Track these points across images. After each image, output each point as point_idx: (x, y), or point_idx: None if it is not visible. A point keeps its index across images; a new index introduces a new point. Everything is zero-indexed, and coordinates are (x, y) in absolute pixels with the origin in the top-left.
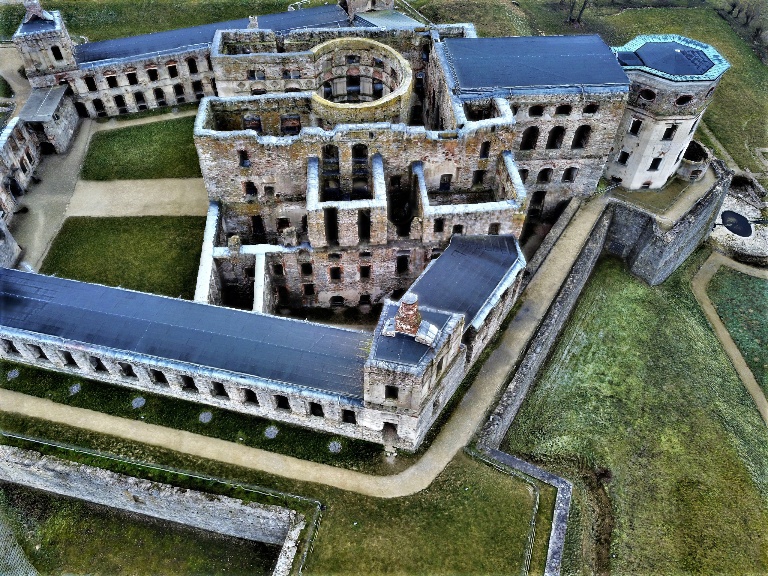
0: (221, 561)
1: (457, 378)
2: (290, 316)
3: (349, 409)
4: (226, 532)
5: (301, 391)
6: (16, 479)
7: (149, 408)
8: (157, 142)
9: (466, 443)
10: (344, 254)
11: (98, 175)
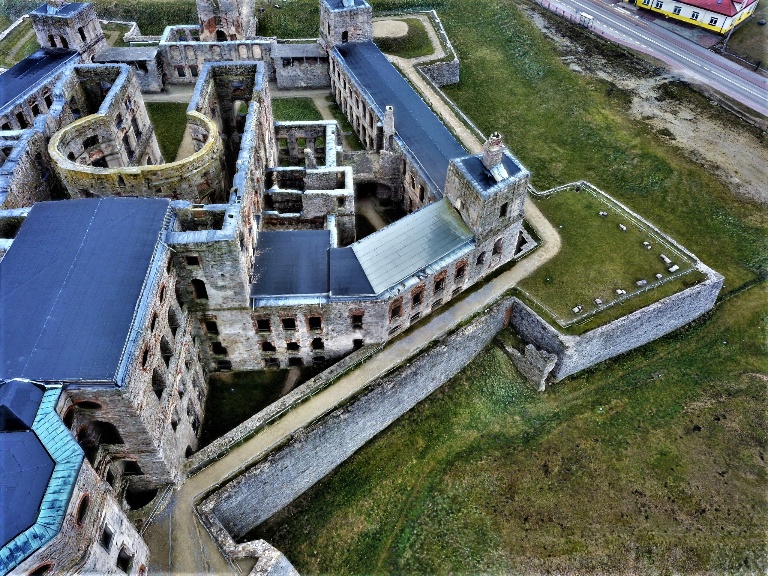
0: None
1: None
2: None
3: None
4: None
5: None
6: None
7: None
8: None
9: None
10: None
11: None
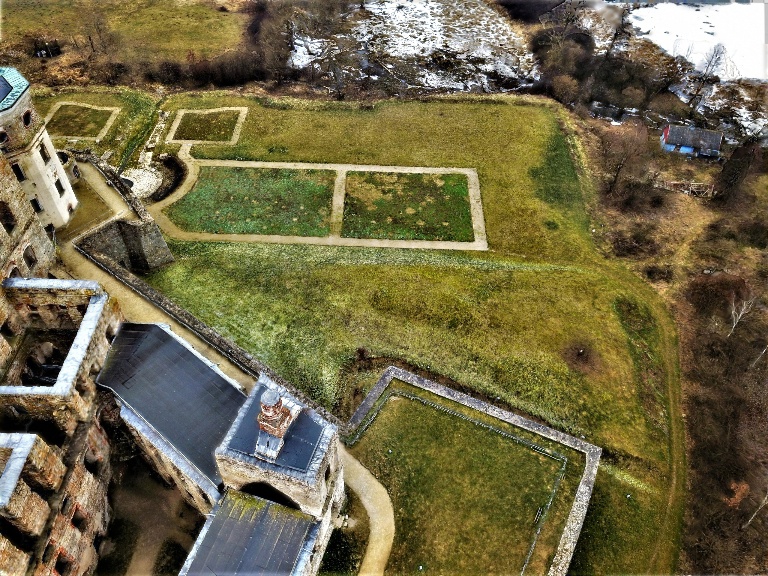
0: None
1: None
2: None
3: None
4: None
5: None
6: None
7: None
8: None
9: (342, 443)
10: (52, 534)
11: None
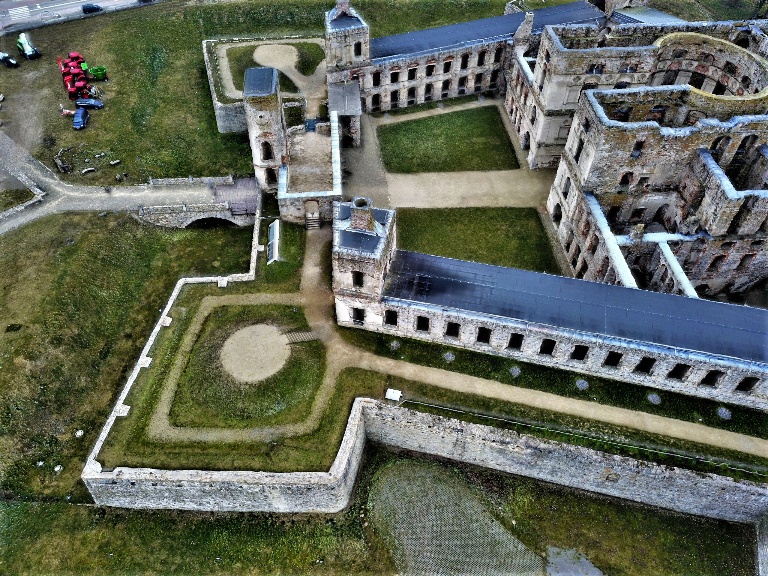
0: (691, 538)
1: None
2: None
3: None
4: (687, 510)
5: None
6: (467, 458)
7: (596, 390)
8: (441, 136)
9: None
10: (739, 242)
11: (402, 168)
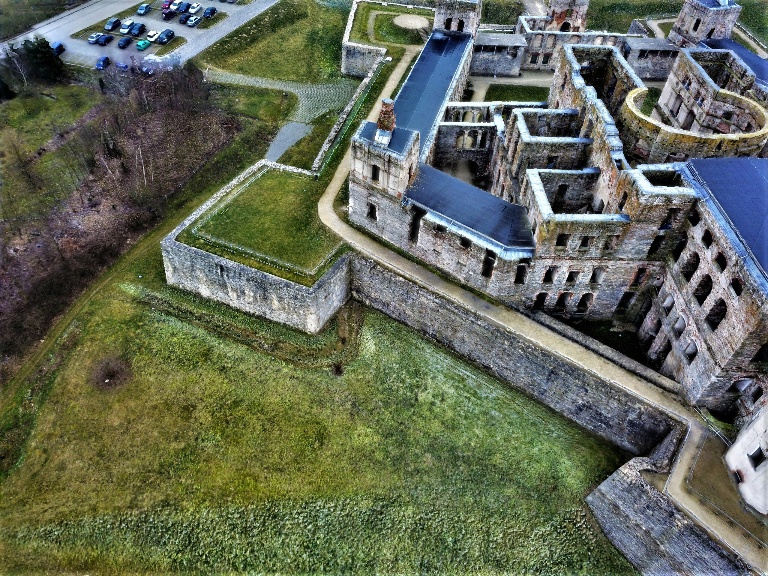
0: None
1: (399, 233)
2: (479, 186)
3: None
4: None
5: None
6: None
7: None
8: None
9: None
10: None
11: None
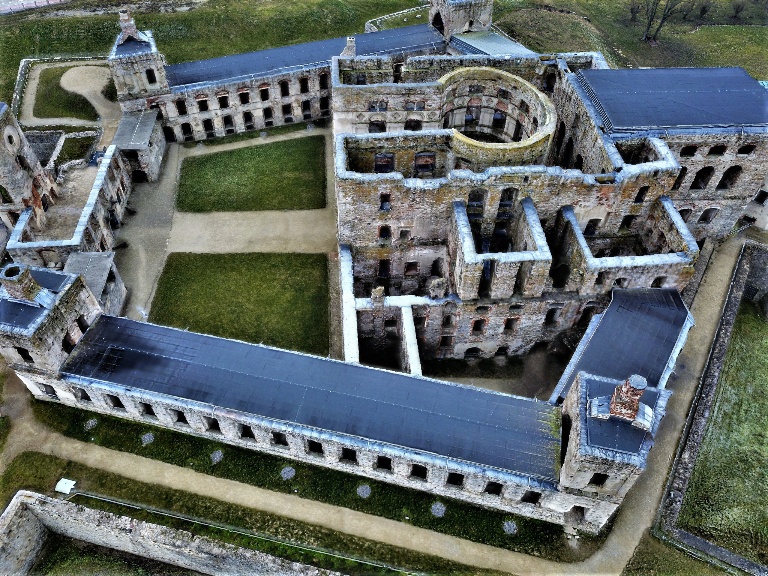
0: None
1: None
2: (423, 368)
3: (536, 491)
4: None
5: (485, 471)
6: (155, 556)
7: (301, 480)
8: (251, 170)
9: (651, 524)
10: (494, 307)
11: (195, 206)
